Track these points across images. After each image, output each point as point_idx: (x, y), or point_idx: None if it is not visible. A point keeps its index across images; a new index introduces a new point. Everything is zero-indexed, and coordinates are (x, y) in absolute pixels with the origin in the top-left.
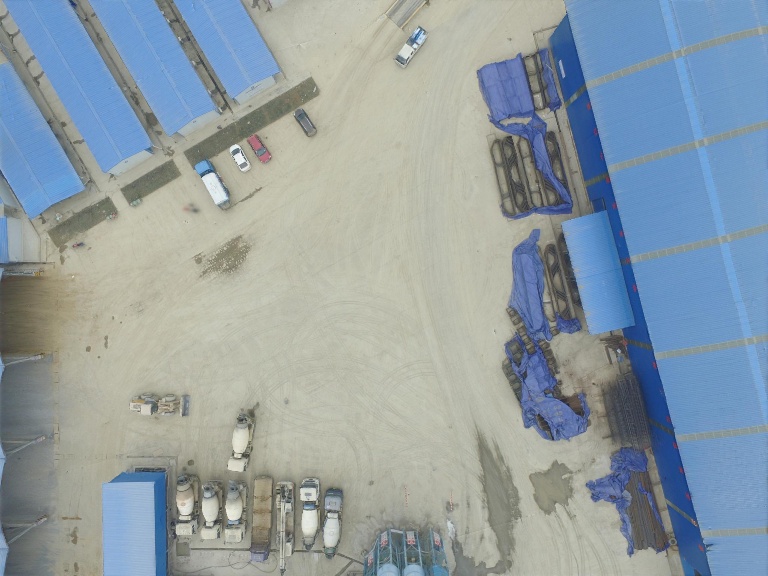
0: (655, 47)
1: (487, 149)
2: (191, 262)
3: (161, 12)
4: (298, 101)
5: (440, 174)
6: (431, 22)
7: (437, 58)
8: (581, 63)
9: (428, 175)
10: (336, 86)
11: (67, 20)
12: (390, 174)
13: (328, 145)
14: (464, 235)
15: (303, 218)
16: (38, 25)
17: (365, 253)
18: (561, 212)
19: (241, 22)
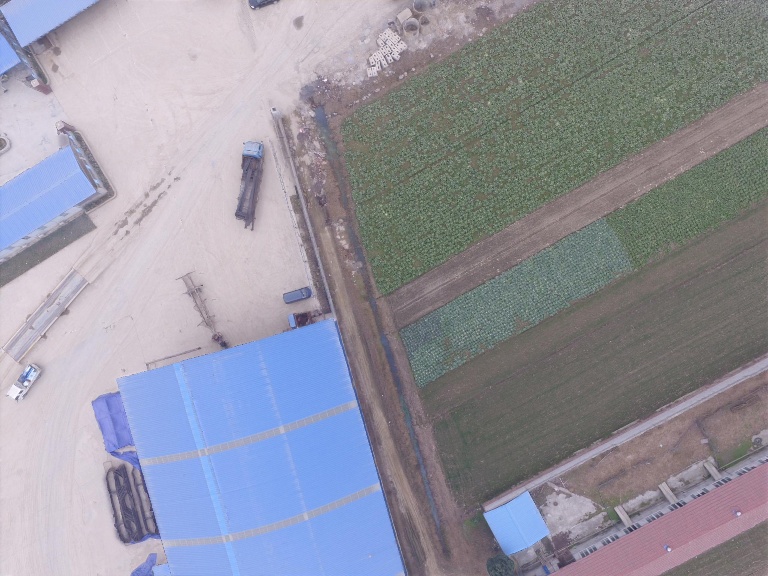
0: (184, 443)
1: (104, 476)
2: None
3: None
4: None
5: (60, 499)
6: (48, 354)
7: (55, 388)
8: (134, 441)
9: (48, 500)
10: None
11: None
12: (12, 499)
13: None
14: (84, 559)
15: None
16: None
17: None
18: None
19: None
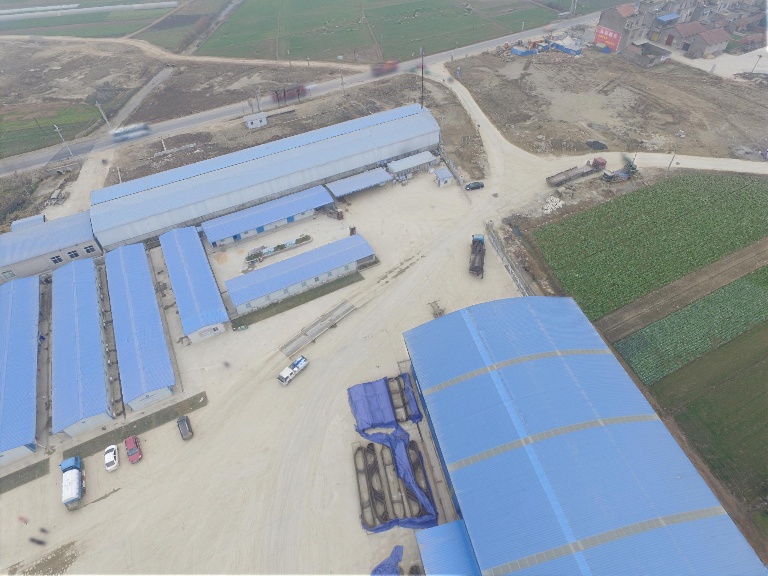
0: (472, 363)
1: (351, 456)
2: (3, 573)
3: (105, 344)
4: (187, 410)
5: (302, 480)
6: (314, 354)
7: (315, 379)
8: (417, 376)
9: (289, 480)
10: (224, 399)
11: (28, 347)
12: (252, 478)
13: (200, 448)
14: (317, 550)
15: (148, 523)
16: (3, 349)
17: (201, 569)
18: (426, 526)
19: (159, 350)
